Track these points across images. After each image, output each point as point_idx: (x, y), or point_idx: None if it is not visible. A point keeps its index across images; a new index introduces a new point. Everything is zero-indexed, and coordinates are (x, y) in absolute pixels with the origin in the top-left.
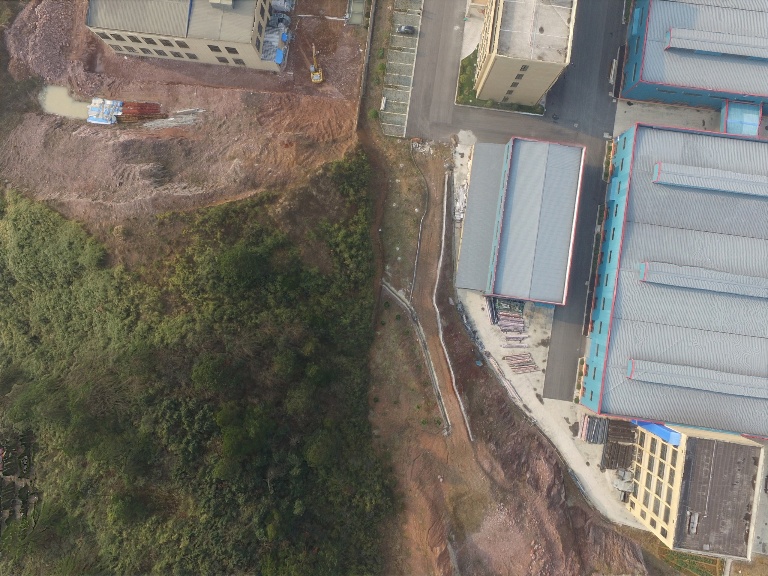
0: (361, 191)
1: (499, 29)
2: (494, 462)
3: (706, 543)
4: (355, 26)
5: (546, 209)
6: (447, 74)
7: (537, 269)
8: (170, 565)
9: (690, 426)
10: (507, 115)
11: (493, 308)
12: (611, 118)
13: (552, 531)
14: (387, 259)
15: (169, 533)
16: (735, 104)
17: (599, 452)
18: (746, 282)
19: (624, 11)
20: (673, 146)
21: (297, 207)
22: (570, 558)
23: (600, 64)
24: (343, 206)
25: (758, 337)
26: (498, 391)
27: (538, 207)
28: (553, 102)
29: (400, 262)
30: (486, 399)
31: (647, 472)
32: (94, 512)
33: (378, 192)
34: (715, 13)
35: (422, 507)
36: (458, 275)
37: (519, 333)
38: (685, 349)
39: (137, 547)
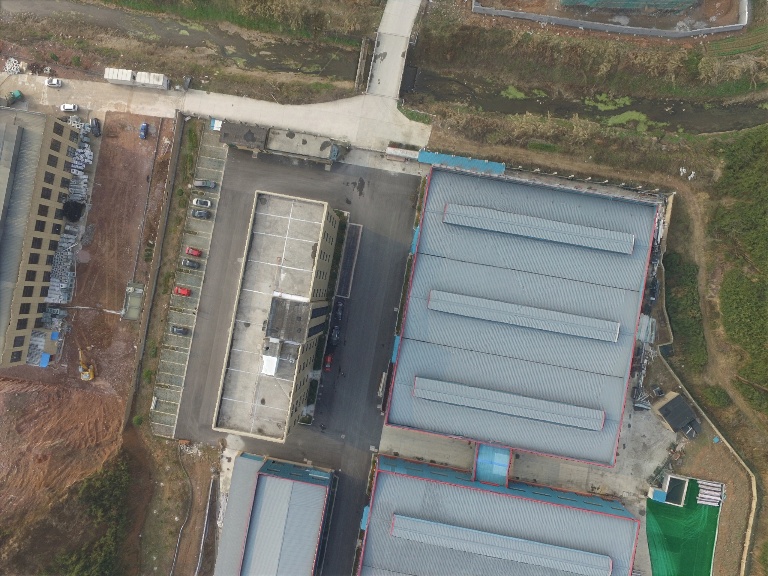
0: (112, 510)
1: (217, 403)
2: None
3: None
4: (131, 321)
5: (287, 547)
6: (219, 376)
7: None
8: None
9: None
10: None
11: None
12: (378, 431)
13: None
14: (143, 569)
15: None
16: None
17: None
18: None
19: (396, 323)
20: (414, 493)
21: (28, 547)
22: None
23: (370, 376)
24: (91, 527)
25: None
26: None
27: (279, 545)
28: (322, 411)
29: (156, 572)
30: None
31: None
32: None
33: (139, 498)
34: (466, 357)
35: None
36: None
37: None
38: None
39: None
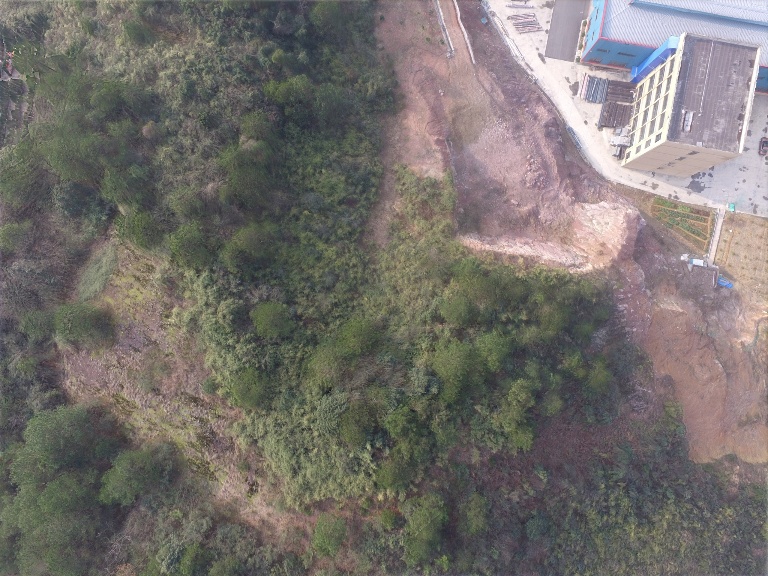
0: None
1: None
2: (495, 85)
3: (699, 141)
4: None
5: None
6: None
7: None
8: (175, 75)
9: None
10: None
11: None
12: None
13: (548, 155)
14: None
15: (175, 51)
16: None
17: (597, 111)
18: None
19: None
20: None
21: None
22: (565, 182)
23: None
24: None
25: None
26: (501, 47)
27: None
28: None
29: None
30: (489, 46)
31: (644, 112)
32: (102, 43)
33: None
34: None
35: (422, 107)
36: None
37: None
38: None
39: (143, 62)
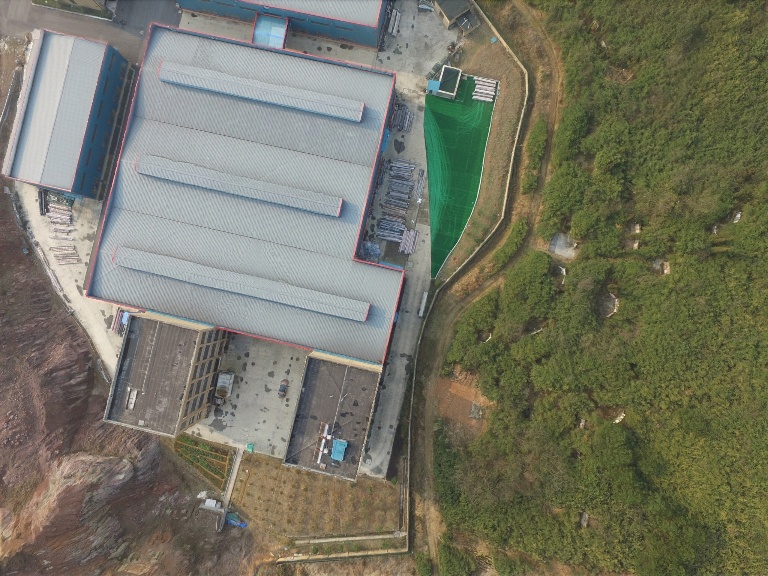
0: None
1: None
2: None
3: (142, 419)
4: None
5: (66, 100)
6: None
7: (51, 156)
8: None
9: (170, 315)
10: (79, 18)
11: (43, 199)
12: (175, 28)
13: (39, 407)
14: None
15: None
16: (266, 17)
17: None
18: (228, 180)
19: None
20: (187, 48)
21: None
22: (54, 434)
23: None
24: None
25: (247, 237)
26: (39, 279)
27: (58, 97)
28: (123, 8)
29: None
30: (17, 283)
31: None
32: None
33: None
34: None
35: None
36: (4, 163)
37: (67, 226)
38: (176, 242)
39: None
